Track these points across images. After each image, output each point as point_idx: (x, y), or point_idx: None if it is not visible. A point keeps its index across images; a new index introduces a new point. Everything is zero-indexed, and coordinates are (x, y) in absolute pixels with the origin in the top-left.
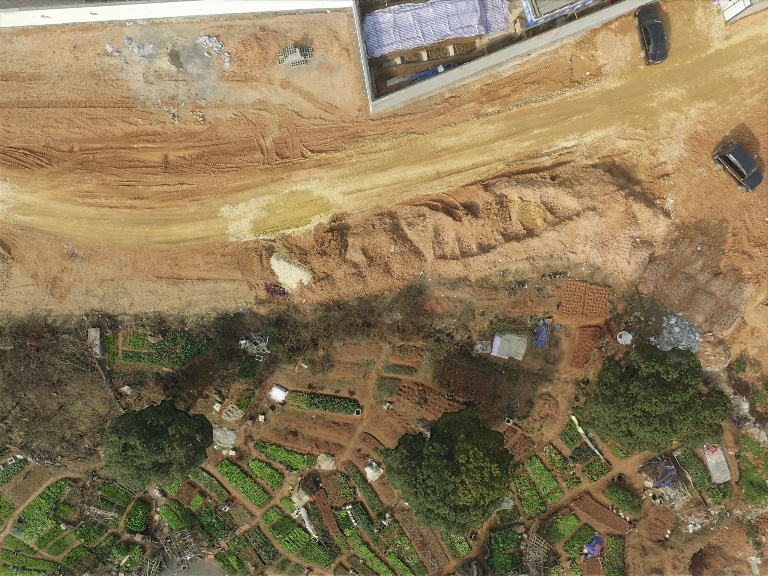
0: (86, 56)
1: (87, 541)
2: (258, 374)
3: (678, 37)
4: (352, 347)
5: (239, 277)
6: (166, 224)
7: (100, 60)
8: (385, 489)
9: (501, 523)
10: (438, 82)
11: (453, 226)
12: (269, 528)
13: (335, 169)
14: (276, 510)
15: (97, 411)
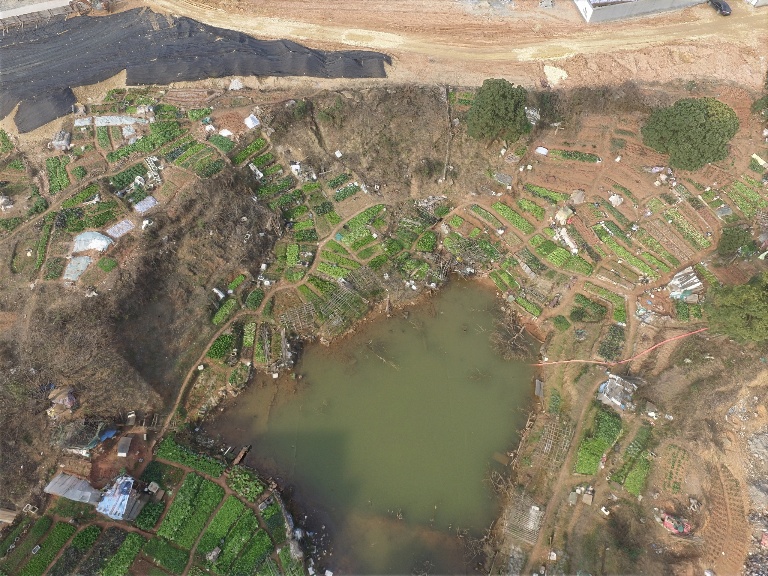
0: (445, 2)
1: (390, 250)
2: (531, 133)
3: (733, 10)
4: (593, 117)
5: (525, 75)
6: (484, 53)
7: (452, 3)
8: (628, 210)
9: (728, 223)
10: (622, 9)
11: (645, 57)
12: (535, 249)
13: (573, 39)
14: (540, 236)
15: (431, 138)
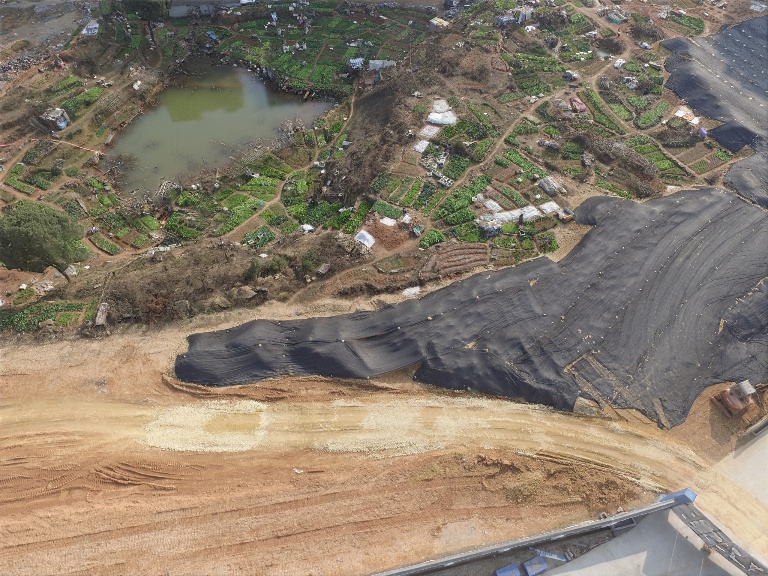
0: None
1: (212, 203)
2: None
3: None
4: None
5: None
6: None
7: None
8: None
9: None
10: None
11: None
12: None
13: None
14: None
15: None
